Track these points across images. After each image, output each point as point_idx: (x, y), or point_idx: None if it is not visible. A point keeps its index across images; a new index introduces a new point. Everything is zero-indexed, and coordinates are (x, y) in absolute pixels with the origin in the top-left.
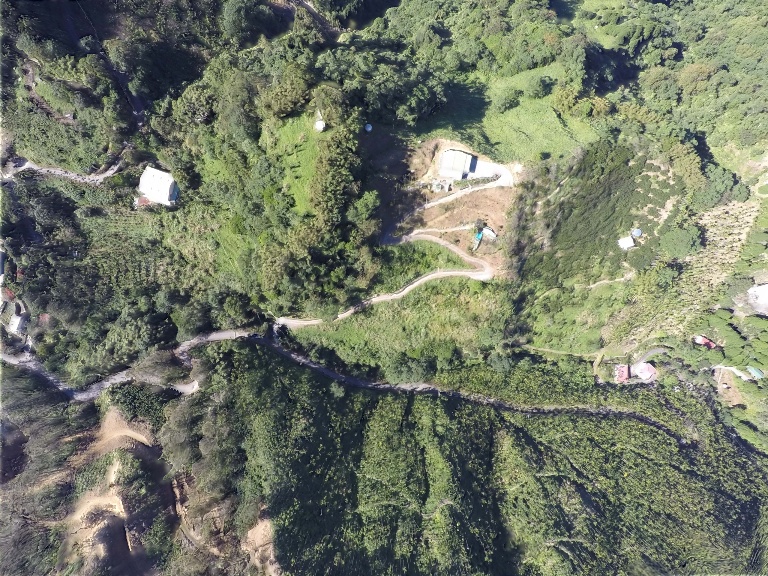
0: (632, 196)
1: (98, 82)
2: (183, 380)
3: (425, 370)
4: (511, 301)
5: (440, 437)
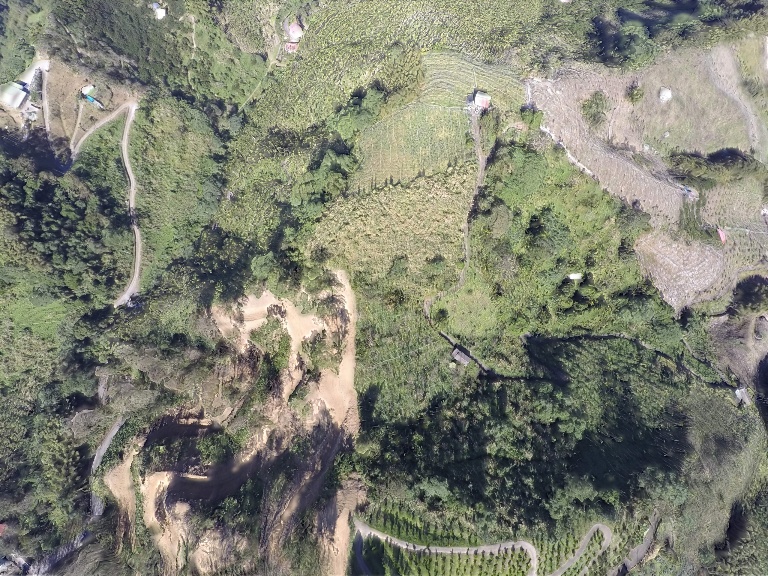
0: (124, 3)
1: None
2: None
3: (209, 180)
4: (169, 97)
5: None
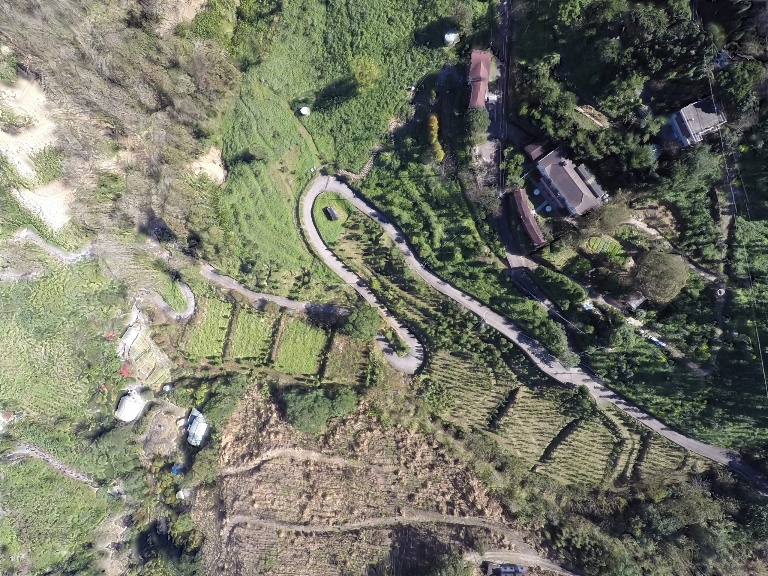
0: None
1: None
2: None
3: None
4: None
5: None
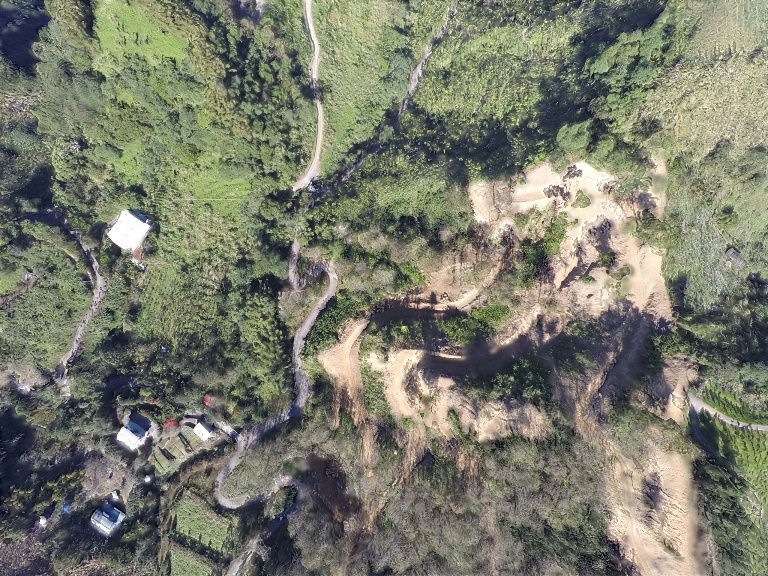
0: None
1: (8, 232)
2: (323, 285)
3: (400, 54)
4: None
5: (463, 41)
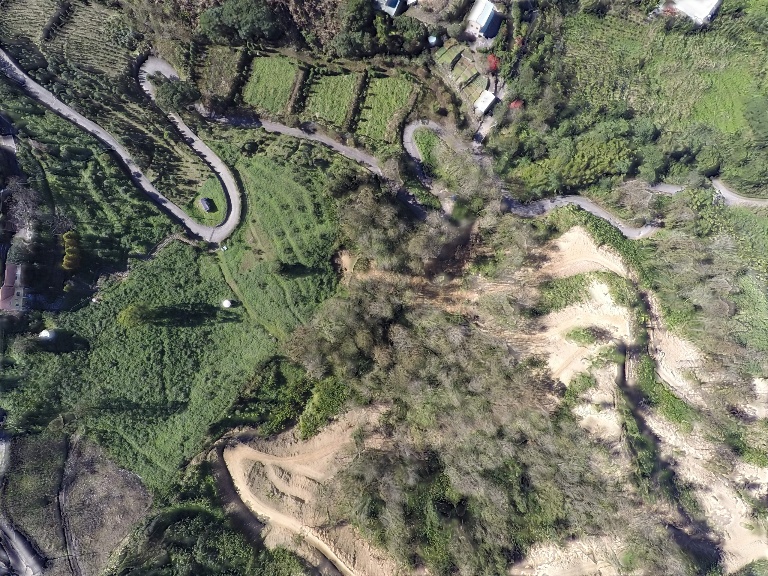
0: None
1: None
2: (635, 222)
3: None
4: None
5: None
